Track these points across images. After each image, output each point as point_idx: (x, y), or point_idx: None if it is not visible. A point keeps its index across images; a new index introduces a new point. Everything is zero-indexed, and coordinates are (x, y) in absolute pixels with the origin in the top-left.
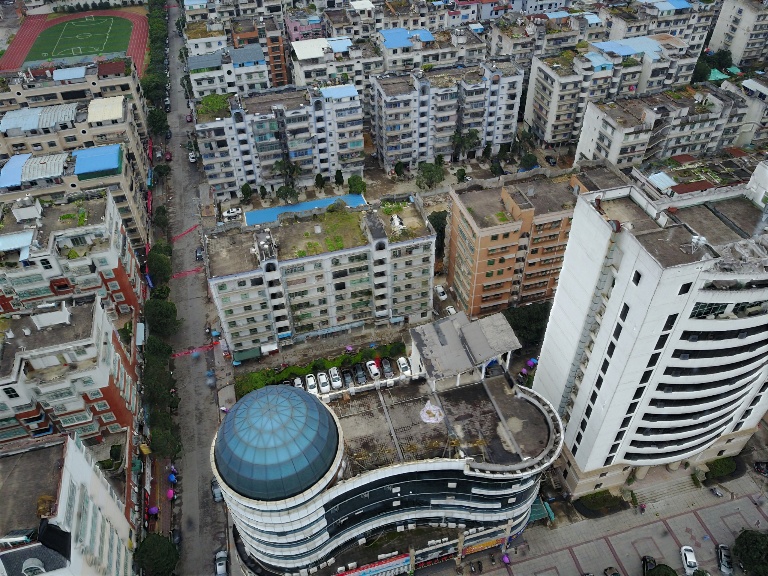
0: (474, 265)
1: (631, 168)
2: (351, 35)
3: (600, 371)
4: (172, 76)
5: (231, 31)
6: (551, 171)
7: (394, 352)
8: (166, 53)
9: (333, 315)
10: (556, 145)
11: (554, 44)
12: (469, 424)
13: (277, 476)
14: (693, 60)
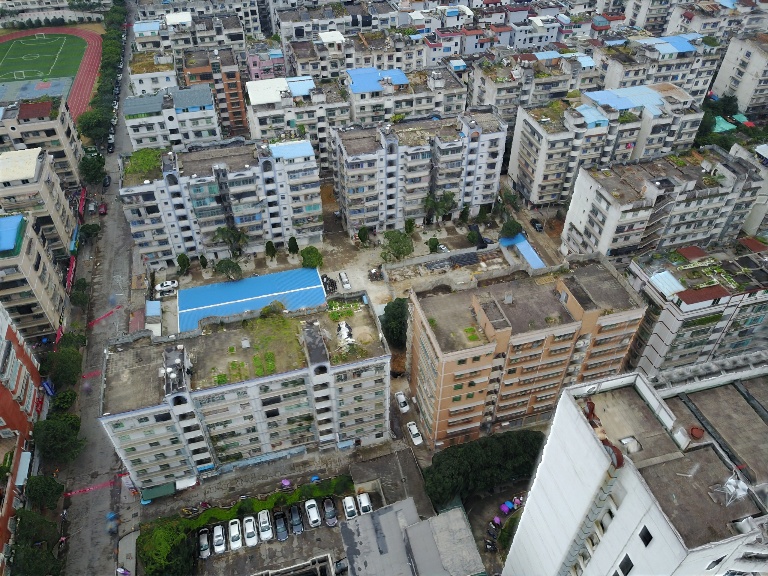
0: (437, 390)
1: (628, 247)
2: (318, 71)
3: None
4: (121, 108)
5: (182, 64)
6: None
7: (340, 489)
8: (118, 80)
9: (266, 441)
10: (543, 205)
11: (543, 89)
12: None
13: None
14: (699, 116)
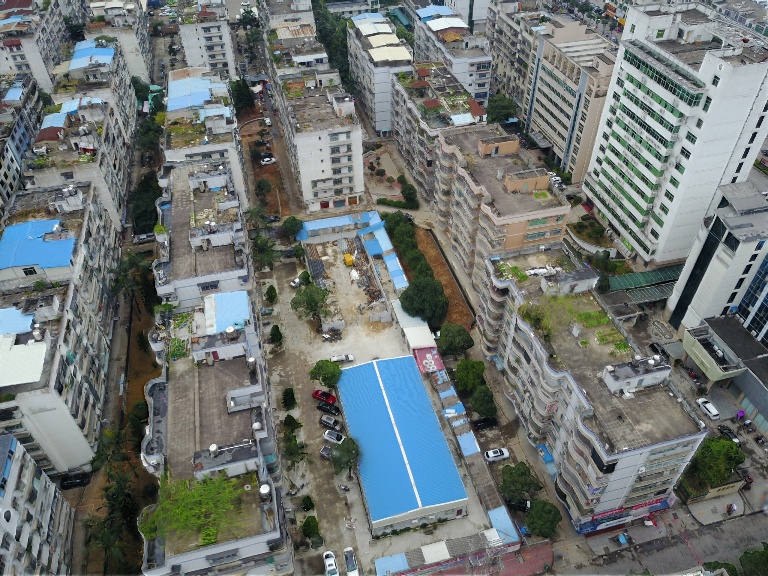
0: None
1: None
2: None
3: (741, 160)
4: None
5: None
6: None
7: None
8: None
9: None
10: None
11: None
12: None
13: None
14: None
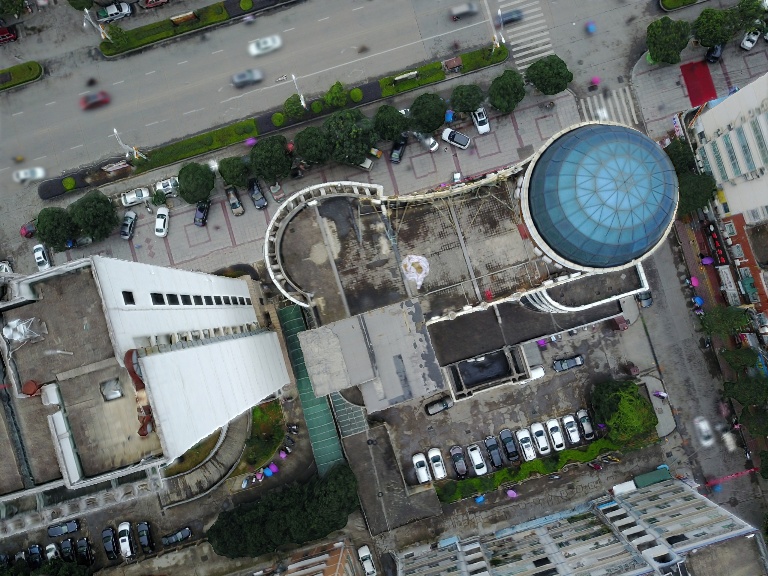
0: None
1: None
2: None
3: (205, 305)
4: None
5: None
6: None
7: (451, 486)
8: None
9: (543, 537)
10: None
11: None
12: (372, 254)
13: (596, 129)
14: None
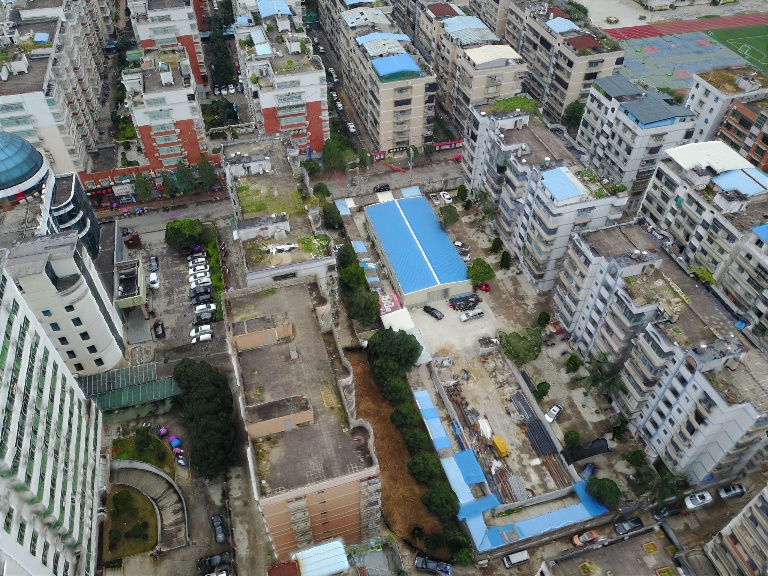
0: None
1: None
2: None
3: None
4: None
5: None
6: (340, 381)
7: (217, 320)
8: None
9: None
10: None
11: None
12: None
13: None
14: None
